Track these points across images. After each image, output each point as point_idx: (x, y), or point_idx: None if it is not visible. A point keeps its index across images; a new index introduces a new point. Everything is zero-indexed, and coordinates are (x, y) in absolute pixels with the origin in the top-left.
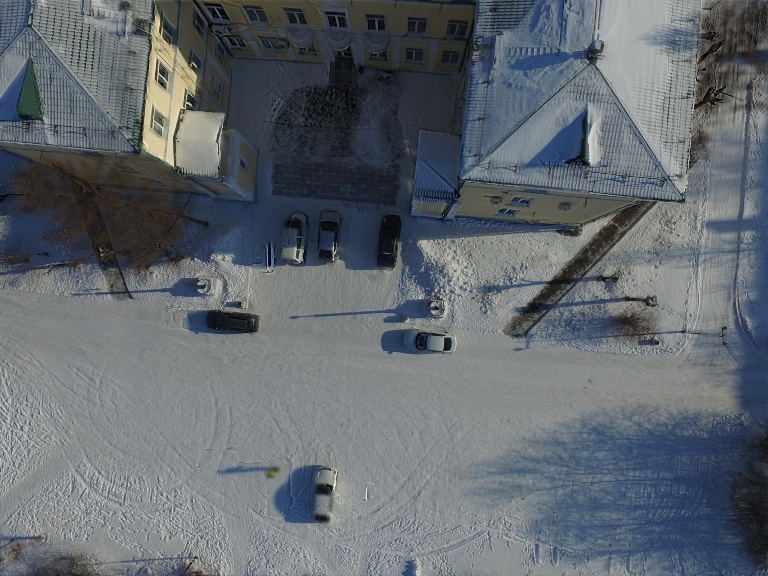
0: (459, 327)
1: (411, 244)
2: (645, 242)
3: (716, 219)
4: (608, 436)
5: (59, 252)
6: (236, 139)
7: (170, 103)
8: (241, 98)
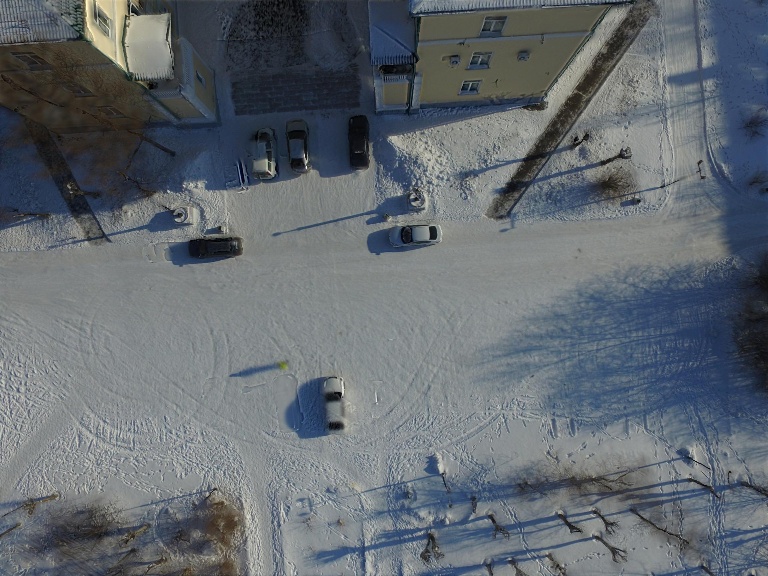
0: (442, 217)
1: (381, 142)
2: (611, 105)
3: (677, 72)
4: (606, 301)
5: (29, 206)
6: (188, 49)
7: (113, 5)
8: (189, 21)
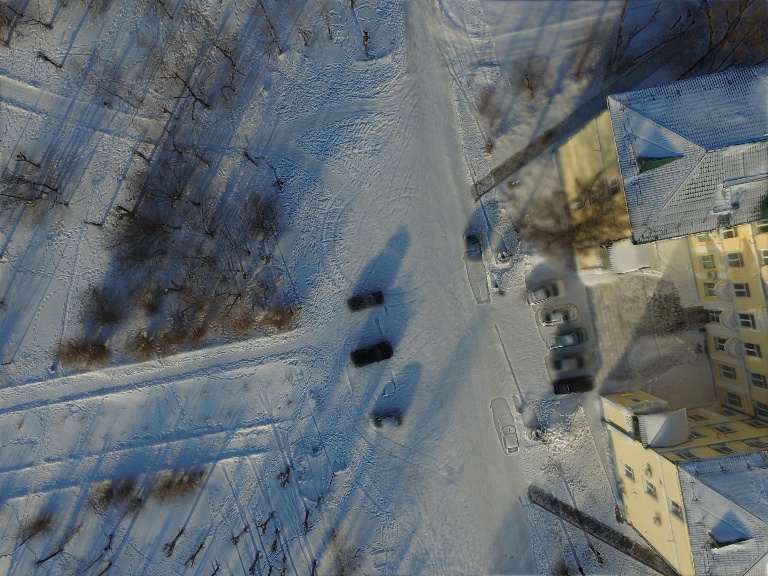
0: (525, 452)
1: (578, 401)
2: (627, 571)
3: None
4: None
5: (496, 136)
6: None
7: None
8: None
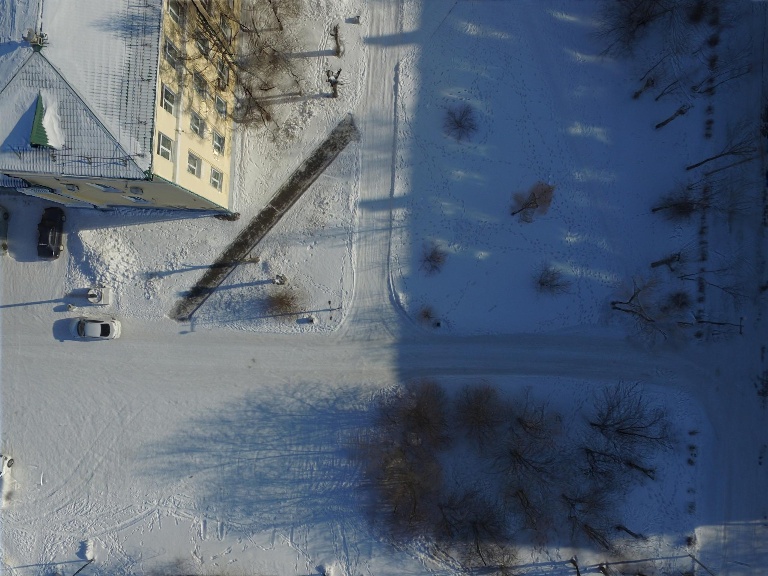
0: (125, 313)
1: (74, 235)
2: (300, 223)
3: (369, 198)
4: (271, 413)
5: None
6: None
7: None
8: None
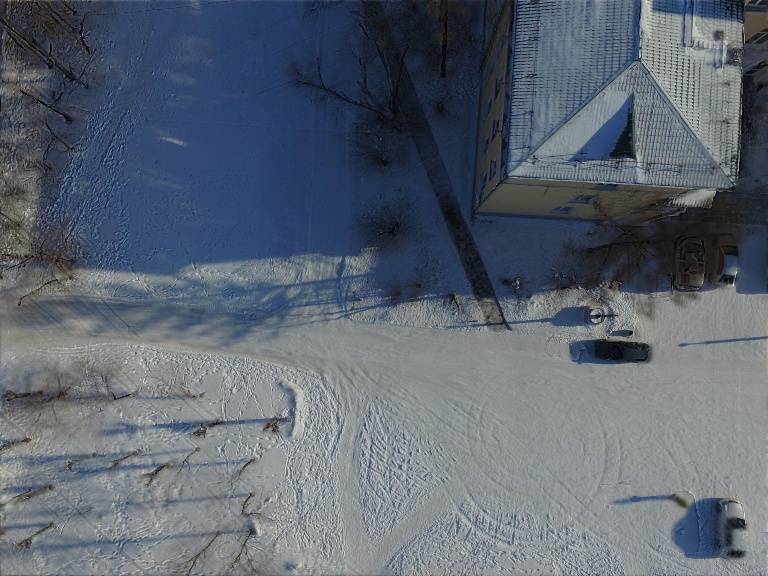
0: None
1: None
2: None
3: None
4: None
5: (435, 284)
6: None
7: None
8: None
